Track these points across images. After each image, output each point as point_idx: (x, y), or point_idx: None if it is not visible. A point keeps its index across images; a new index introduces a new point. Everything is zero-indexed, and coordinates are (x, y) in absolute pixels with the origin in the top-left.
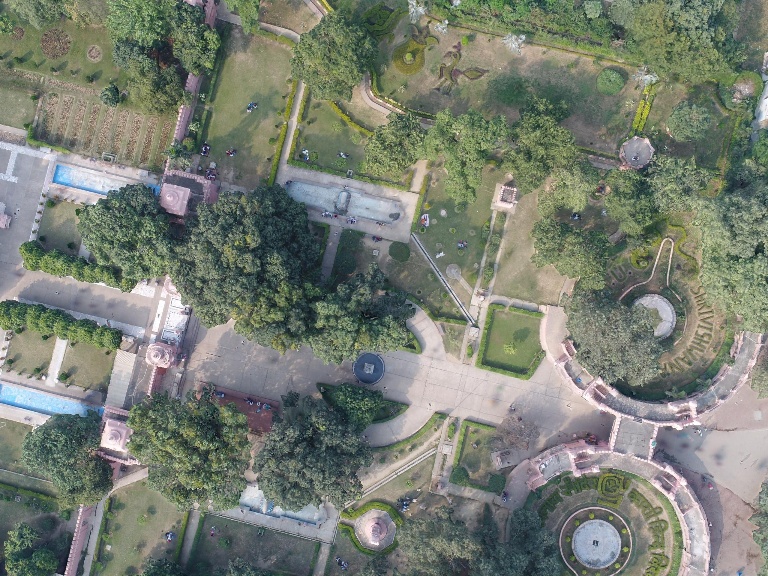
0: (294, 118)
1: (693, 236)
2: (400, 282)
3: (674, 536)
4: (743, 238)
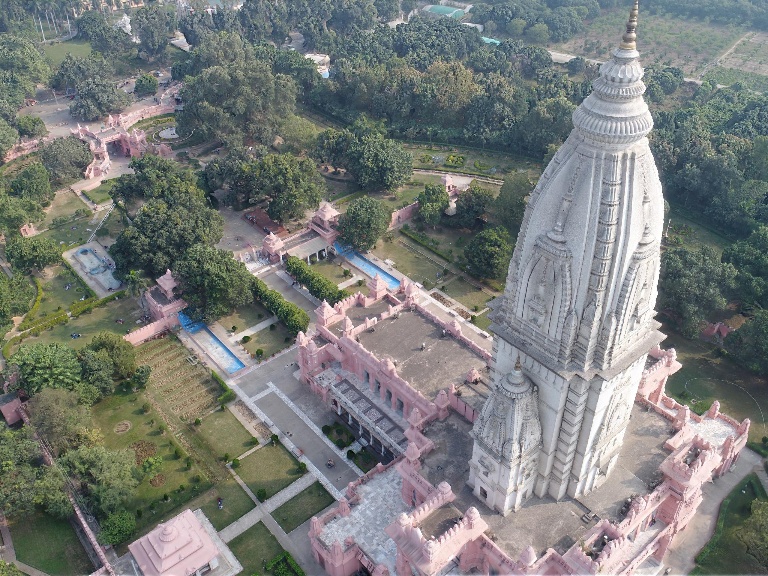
0: None
1: None
2: None
3: (142, 124)
4: None
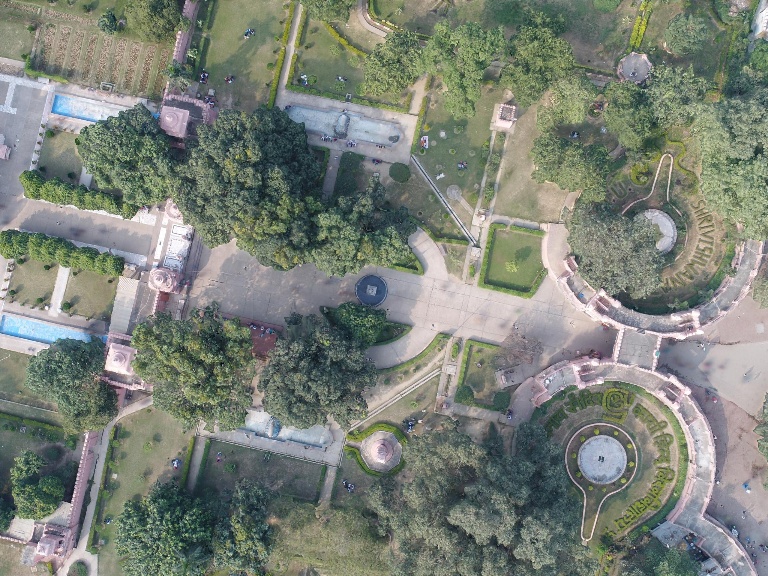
0: (292, 43)
1: (692, 151)
2: (401, 204)
3: (679, 449)
4: (742, 139)
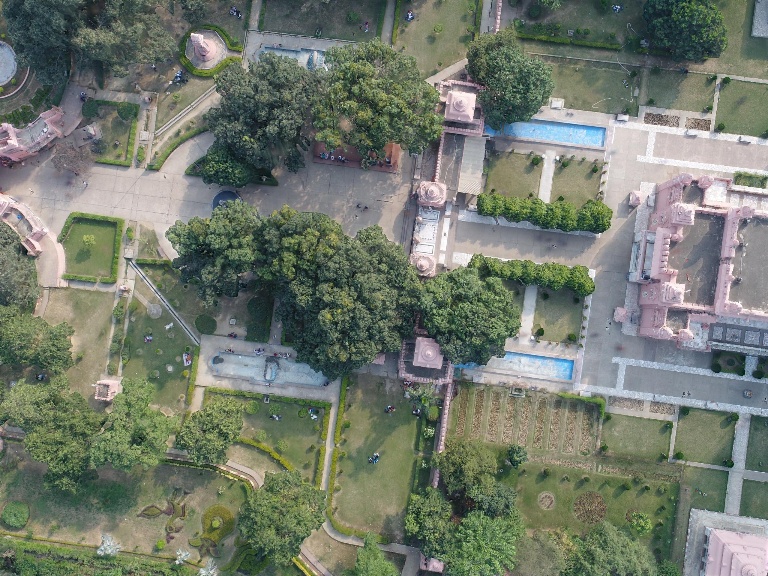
0: (330, 451)
1: None
2: None
3: None
4: None
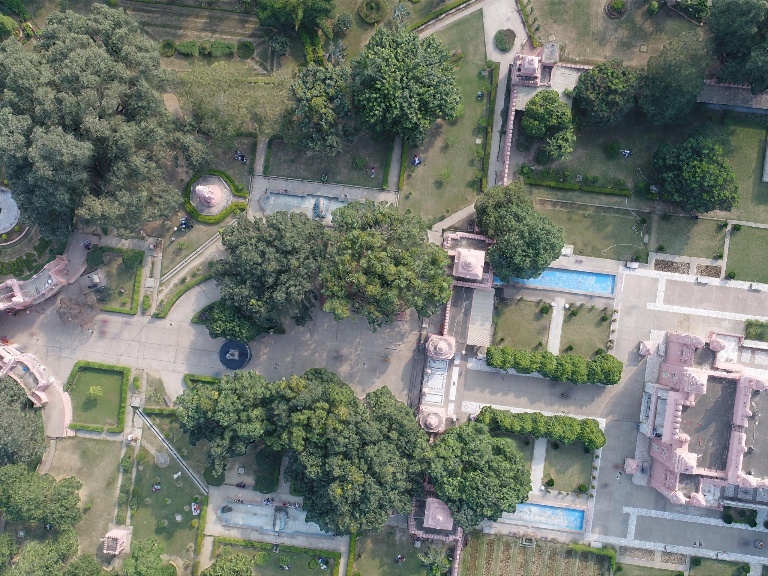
0: None
1: None
2: None
3: None
4: None
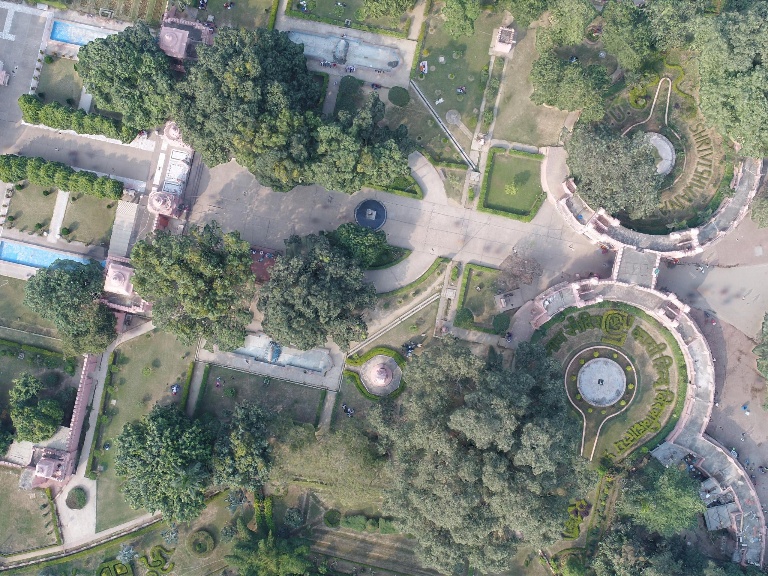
0: None
1: (690, 75)
2: None
3: (679, 371)
4: (741, 50)
